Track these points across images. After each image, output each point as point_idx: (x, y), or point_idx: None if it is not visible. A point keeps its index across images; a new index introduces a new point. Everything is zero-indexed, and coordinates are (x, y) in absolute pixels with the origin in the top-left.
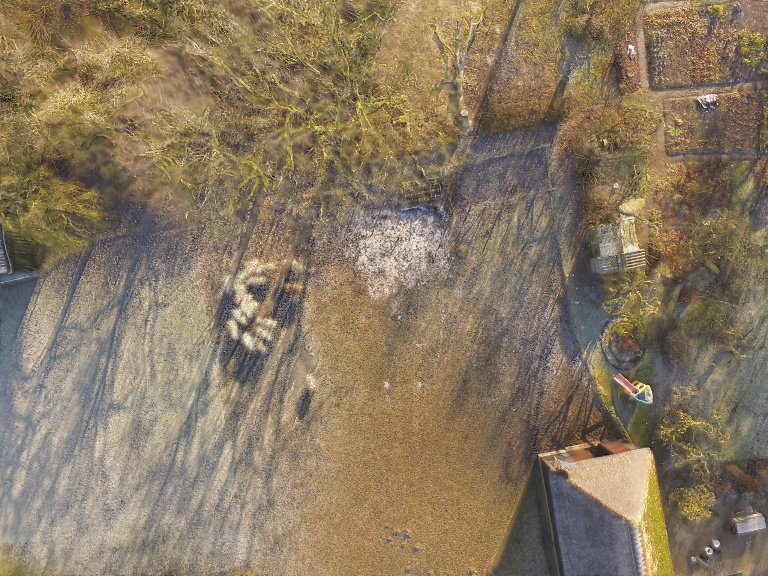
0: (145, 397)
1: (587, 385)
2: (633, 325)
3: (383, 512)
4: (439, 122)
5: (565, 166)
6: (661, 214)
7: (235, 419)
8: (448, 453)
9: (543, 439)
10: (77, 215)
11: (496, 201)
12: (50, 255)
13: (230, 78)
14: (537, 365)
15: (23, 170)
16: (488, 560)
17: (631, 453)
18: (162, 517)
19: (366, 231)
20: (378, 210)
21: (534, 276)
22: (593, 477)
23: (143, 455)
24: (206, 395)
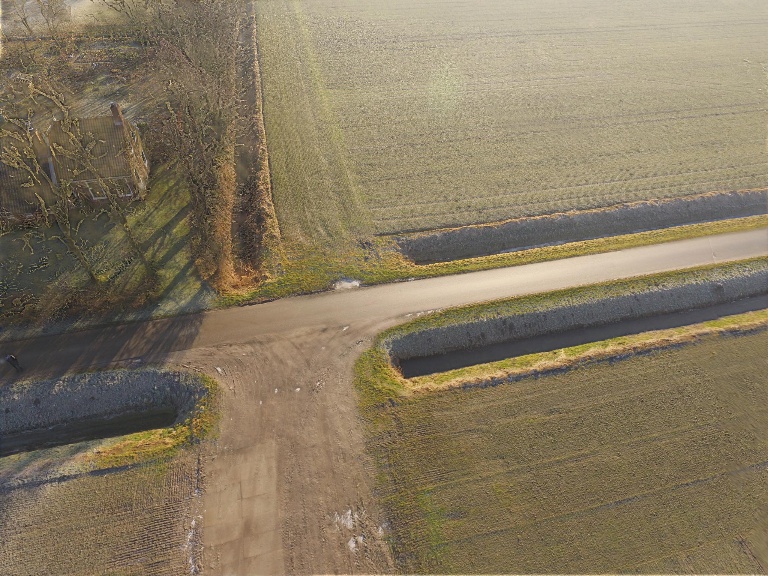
0: None
1: None
2: None
3: None
4: None
5: None
6: None
7: None
8: None
9: None
10: None
11: None
12: None
13: None
14: None
15: None
16: None
17: None
18: None
19: None
20: None
21: None
22: None
23: None
24: None
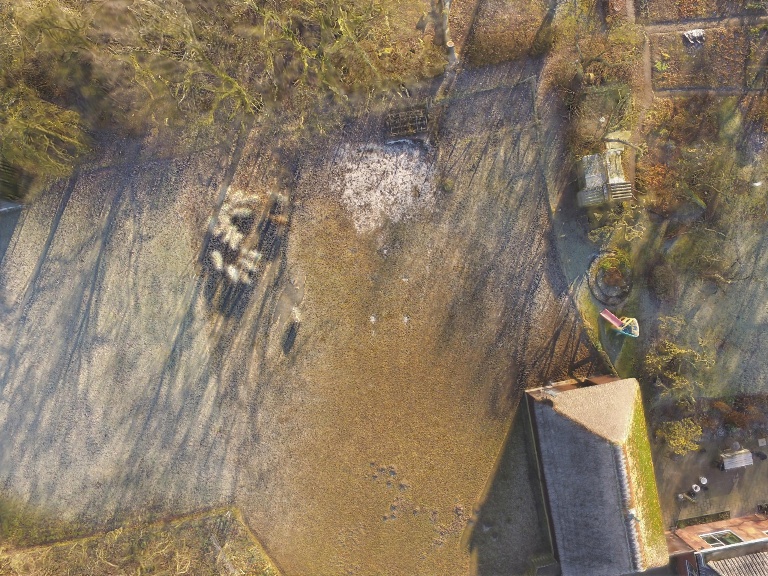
0: (129, 330)
1: (574, 321)
2: (620, 260)
3: (369, 448)
4: (424, 51)
5: (551, 100)
6: (648, 149)
7: (220, 353)
8: (434, 389)
9: (530, 375)
10: (60, 138)
11: (482, 135)
12: (34, 186)
13: (215, 7)
14: (524, 300)
15: (4, 85)
16: (474, 497)
17: (617, 383)
18: (146, 452)
19: (352, 164)
20: (364, 143)
21: (520, 211)
22: (578, 405)
23: (127, 389)
24: (191, 328)
